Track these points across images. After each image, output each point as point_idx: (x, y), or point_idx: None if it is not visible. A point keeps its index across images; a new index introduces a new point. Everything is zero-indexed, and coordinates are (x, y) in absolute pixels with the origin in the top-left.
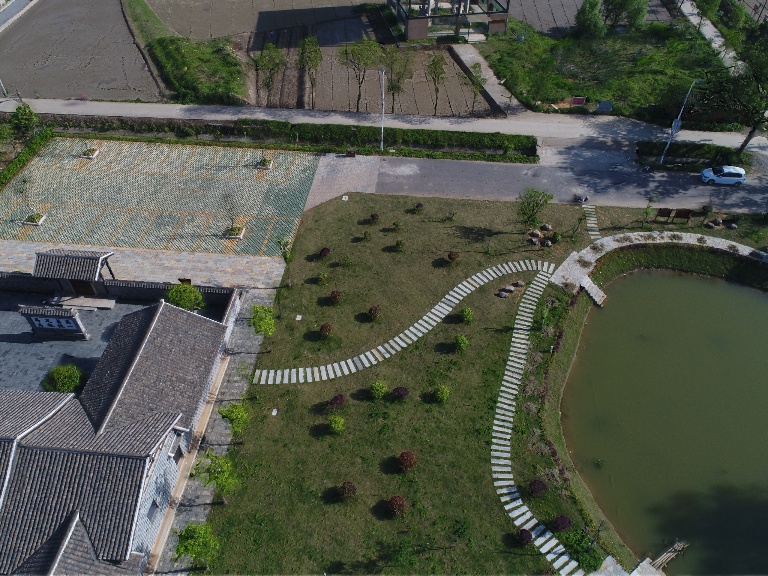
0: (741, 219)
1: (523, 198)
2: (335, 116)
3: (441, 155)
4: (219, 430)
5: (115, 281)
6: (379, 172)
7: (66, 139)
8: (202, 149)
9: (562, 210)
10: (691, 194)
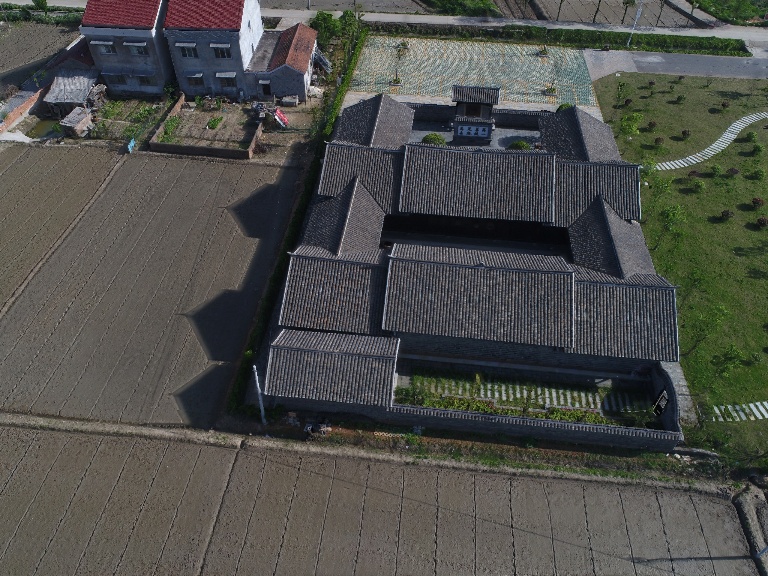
0: None
1: None
2: (579, 25)
3: (675, 50)
4: None
5: (500, 110)
6: (634, 60)
7: (378, 37)
8: (488, 44)
9: None
10: None
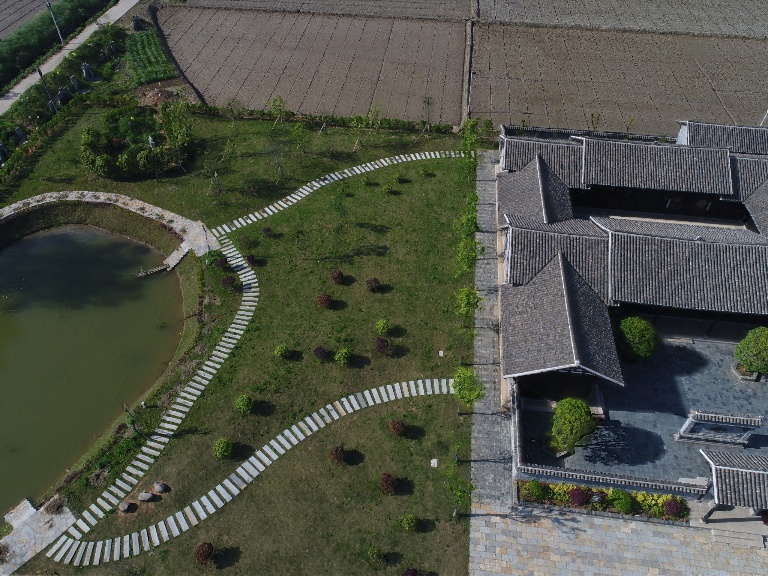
0: None
1: None
2: None
3: None
4: (487, 339)
5: (690, 485)
6: None
7: None
8: None
9: None
10: None
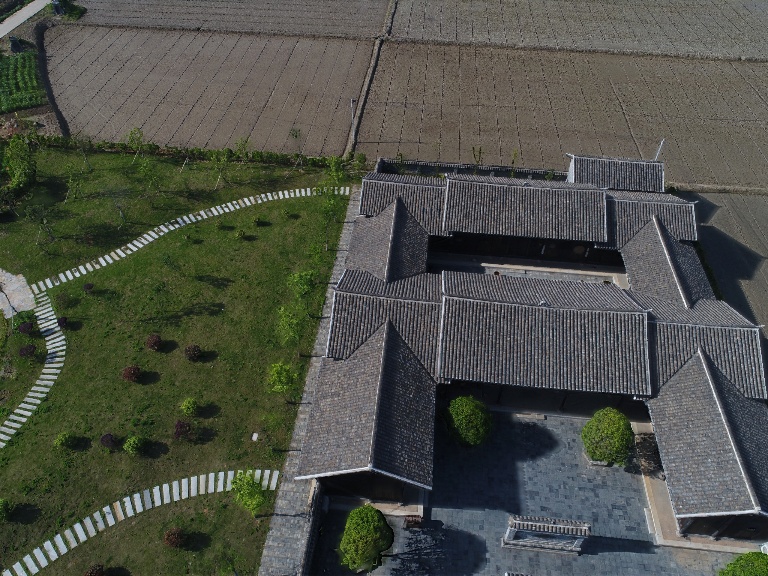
0: None
1: None
2: None
3: None
4: None
5: None
6: None
7: None
8: None
9: None
10: None
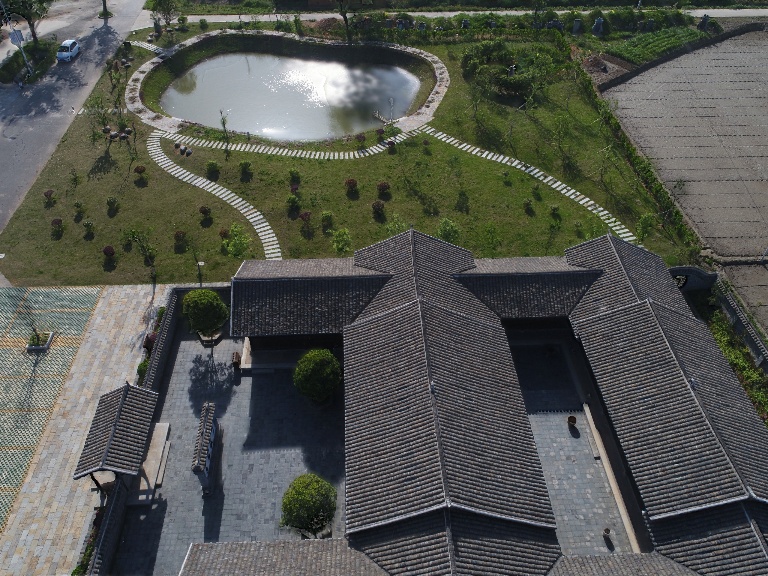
0: (127, 52)
1: (90, 113)
2: None
3: None
4: None
5: None
6: None
7: None
8: None
9: (82, 123)
10: (83, 68)
